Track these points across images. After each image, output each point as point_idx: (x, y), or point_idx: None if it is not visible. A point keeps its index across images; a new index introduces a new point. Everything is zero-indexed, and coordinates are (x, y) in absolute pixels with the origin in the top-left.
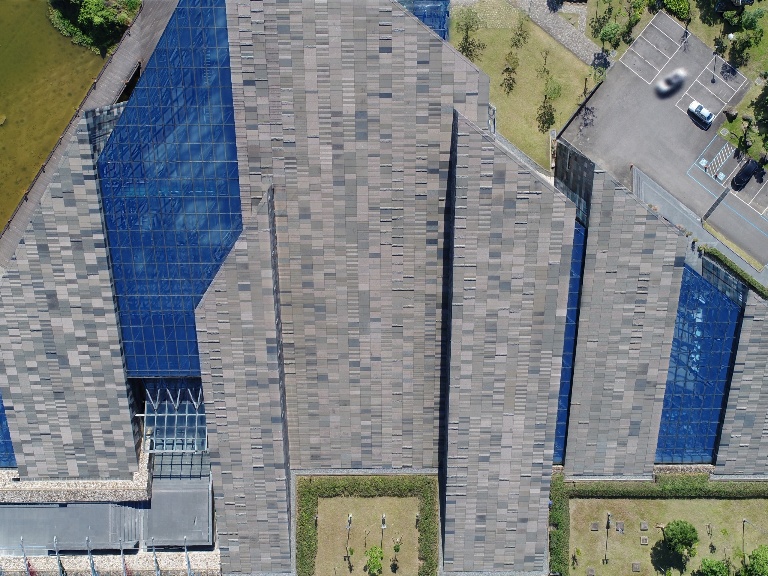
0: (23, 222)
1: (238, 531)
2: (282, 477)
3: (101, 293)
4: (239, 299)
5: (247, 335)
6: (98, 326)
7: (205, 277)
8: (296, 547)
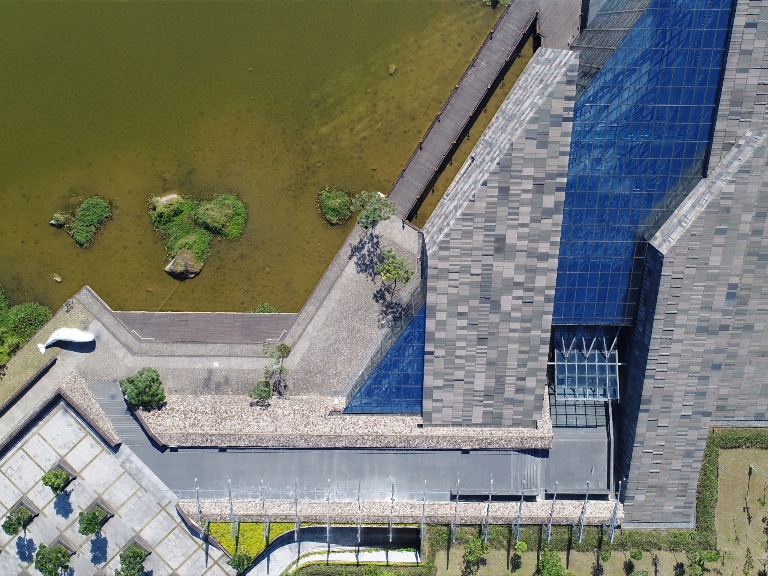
0: (417, 171)
1: (648, 480)
2: (706, 425)
3: (550, 237)
4: (712, 243)
5: (710, 280)
6: (538, 271)
7: (652, 223)
8: (696, 497)
